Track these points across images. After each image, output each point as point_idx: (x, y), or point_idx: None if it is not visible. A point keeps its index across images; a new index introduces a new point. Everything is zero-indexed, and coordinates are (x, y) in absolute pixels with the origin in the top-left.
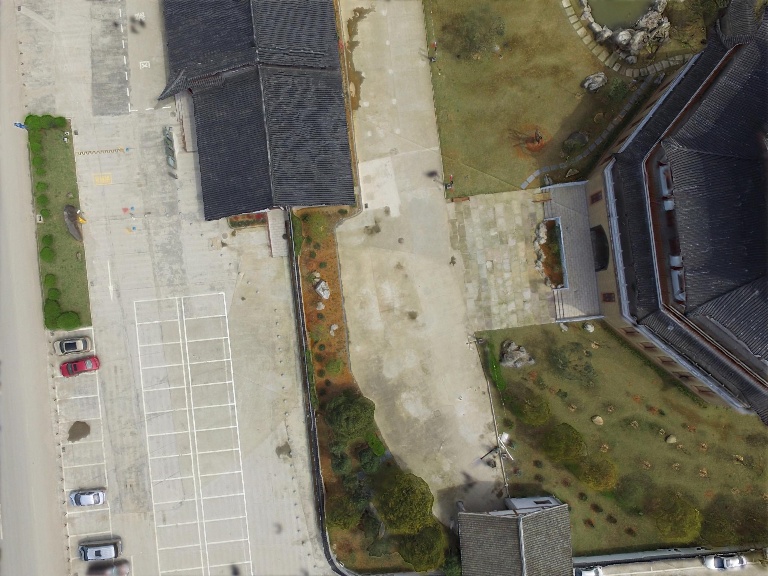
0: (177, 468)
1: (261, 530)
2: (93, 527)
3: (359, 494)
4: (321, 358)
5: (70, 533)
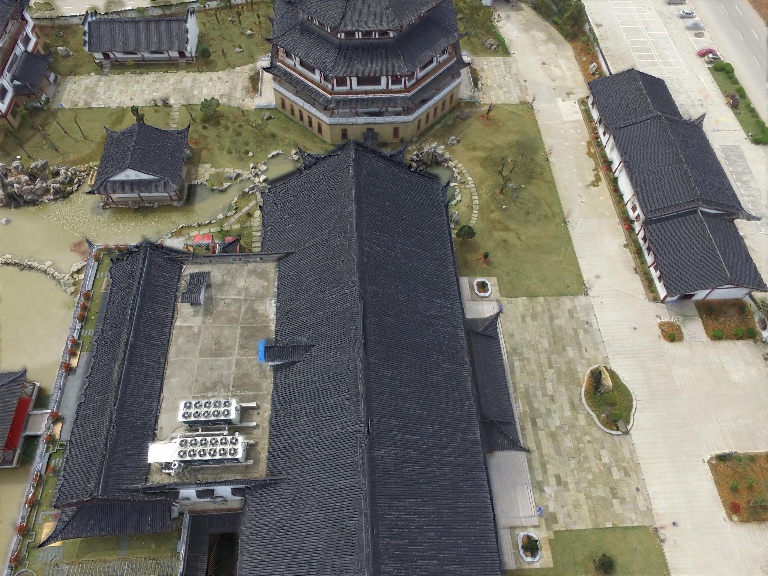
0: (649, 23)
1: (604, 4)
2: (682, 8)
3: (565, 2)
4: (589, 48)
5: (691, 6)
